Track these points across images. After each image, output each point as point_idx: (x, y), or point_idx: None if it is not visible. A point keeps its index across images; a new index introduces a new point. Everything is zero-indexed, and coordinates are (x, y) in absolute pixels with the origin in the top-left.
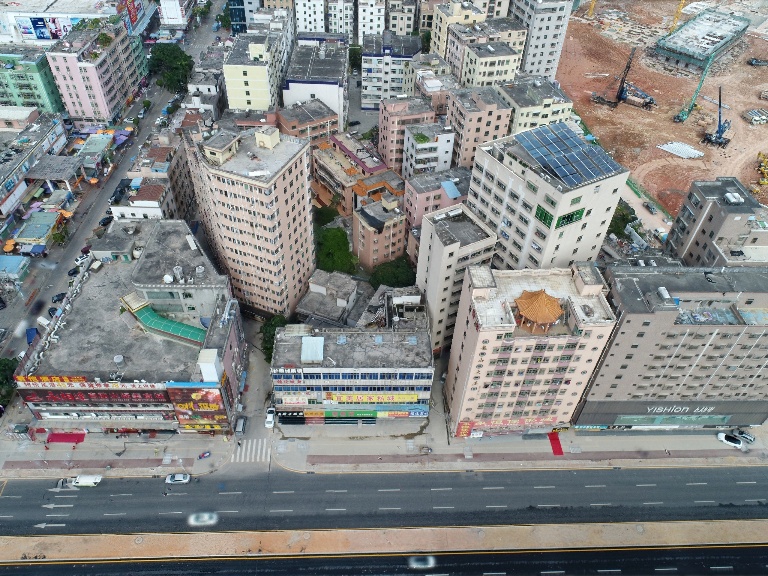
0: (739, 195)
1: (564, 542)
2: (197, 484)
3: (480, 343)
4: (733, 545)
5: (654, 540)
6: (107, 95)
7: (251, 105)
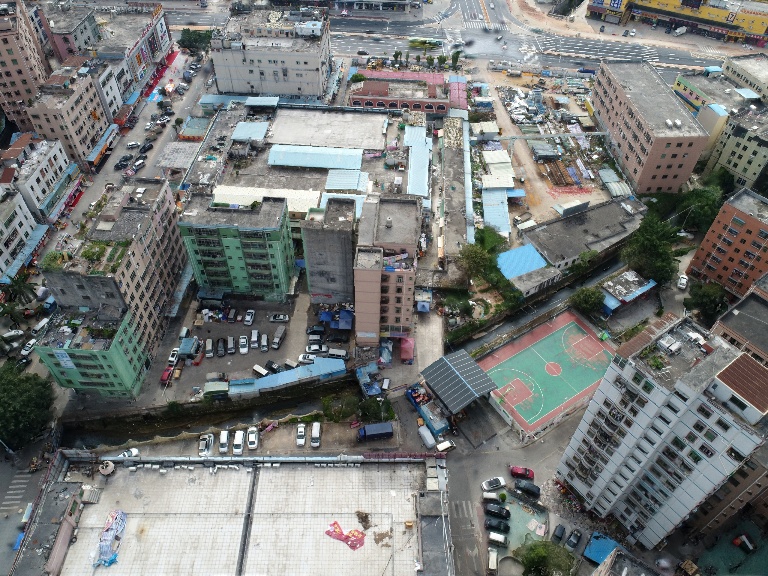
0: None
1: None
2: None
3: None
4: None
5: None
6: None
7: None
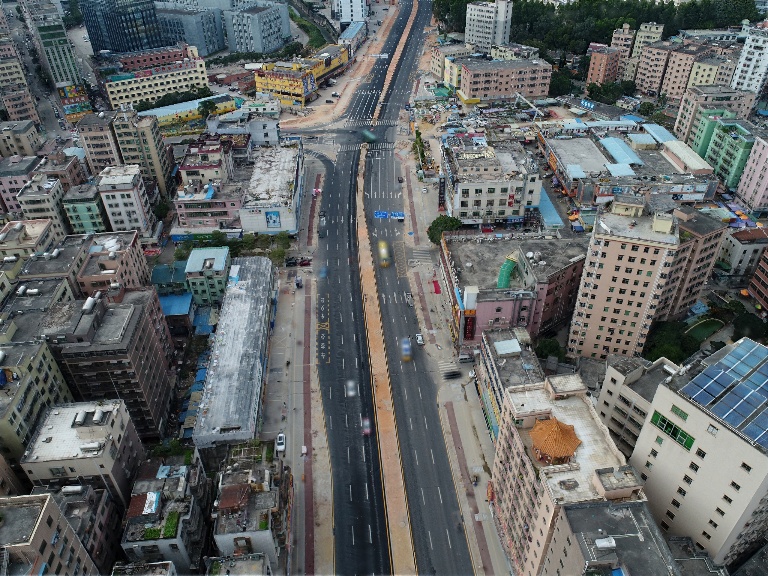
0: None
1: None
2: (418, 349)
3: None
4: None
5: None
6: None
7: None
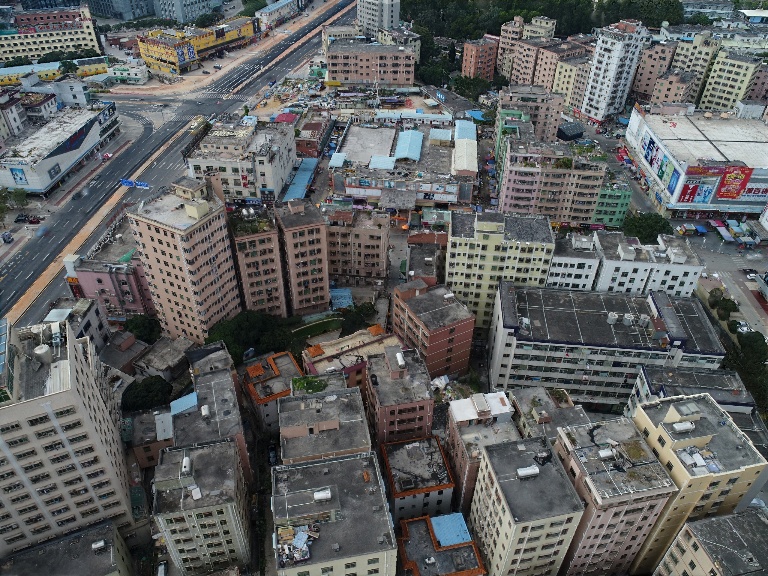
0: None
1: None
2: None
3: None
4: None
5: None
6: (512, 199)
7: None
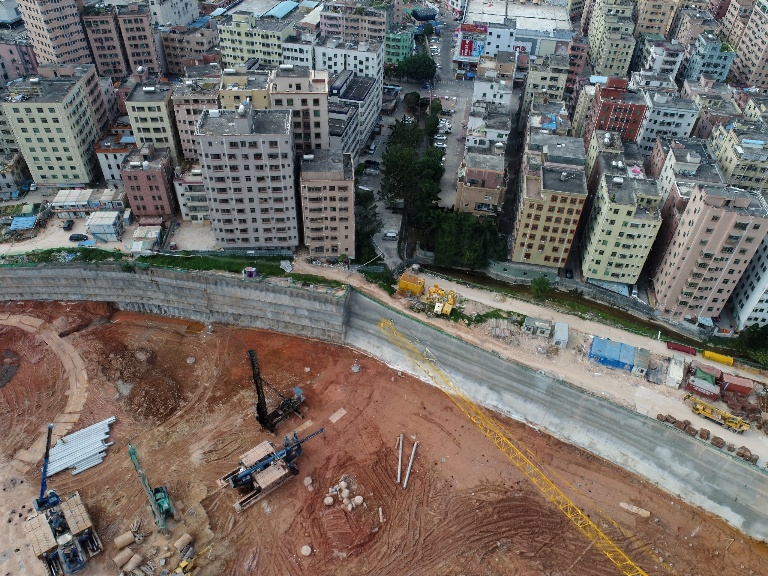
0: None
1: None
2: None
3: None
4: None
5: None
6: None
7: None
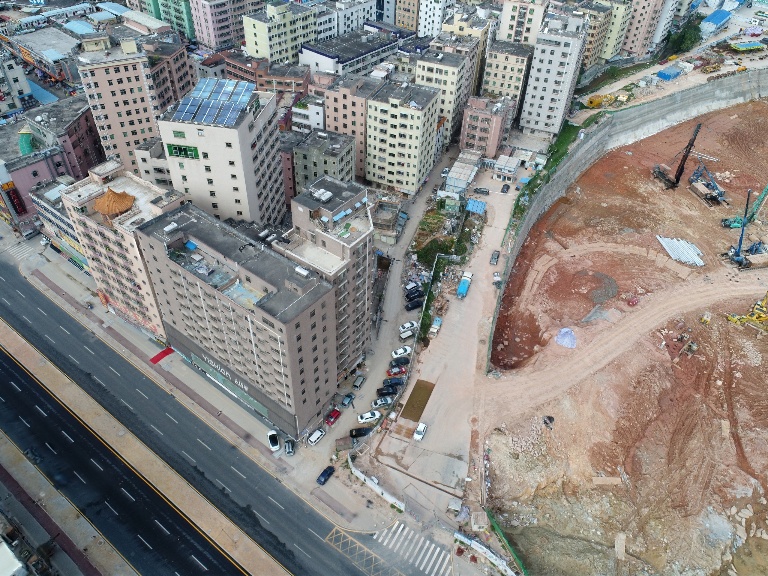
0: (329, 194)
1: (71, 402)
2: None
3: (67, 209)
4: (158, 491)
5: (118, 445)
6: (218, 30)
7: (259, 54)
